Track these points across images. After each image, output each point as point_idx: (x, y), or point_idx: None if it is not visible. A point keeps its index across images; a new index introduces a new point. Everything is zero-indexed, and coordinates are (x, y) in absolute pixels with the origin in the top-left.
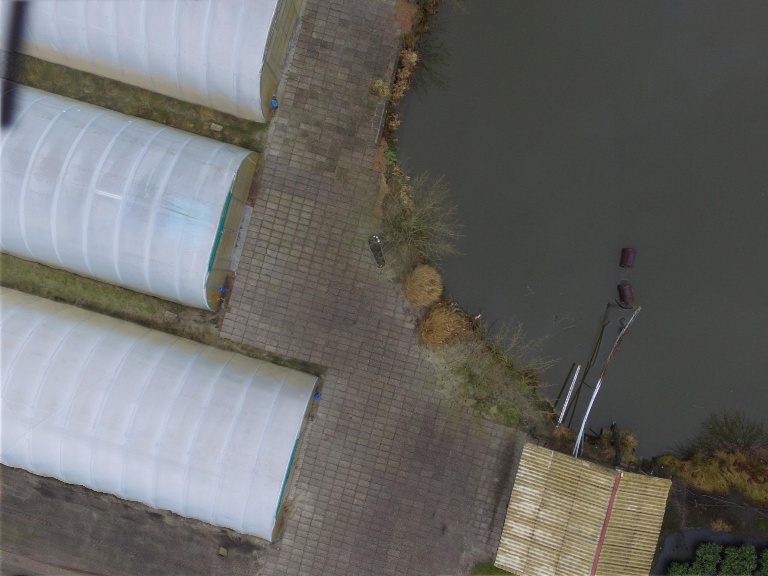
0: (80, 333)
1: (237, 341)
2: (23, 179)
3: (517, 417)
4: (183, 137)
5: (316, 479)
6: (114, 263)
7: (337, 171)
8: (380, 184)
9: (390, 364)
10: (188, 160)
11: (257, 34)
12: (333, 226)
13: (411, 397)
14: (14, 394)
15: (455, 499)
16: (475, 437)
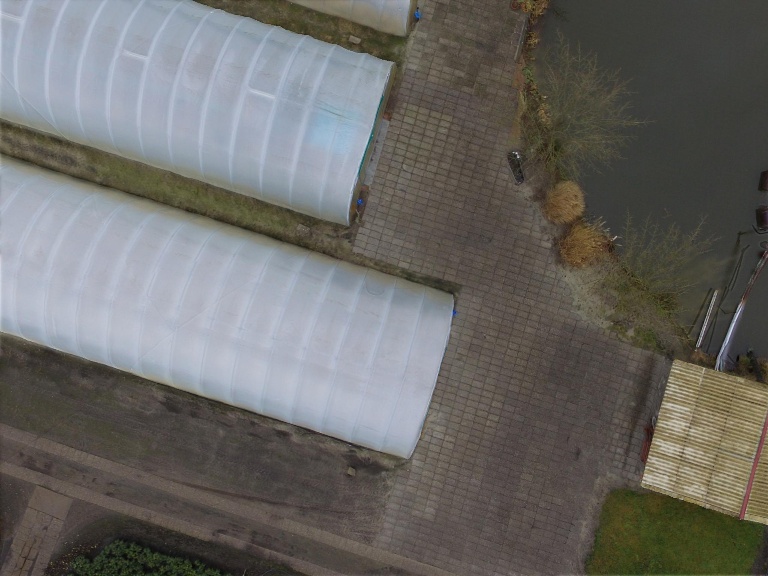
0: (220, 238)
1: (370, 256)
2: (175, 74)
3: (654, 340)
4: (327, 44)
5: (448, 399)
6: (259, 166)
7: (475, 87)
8: (518, 101)
9: (526, 283)
10: (339, 62)
11: None
12: (470, 142)
13: (547, 317)
14: (160, 293)
15: (590, 423)
16: (611, 360)
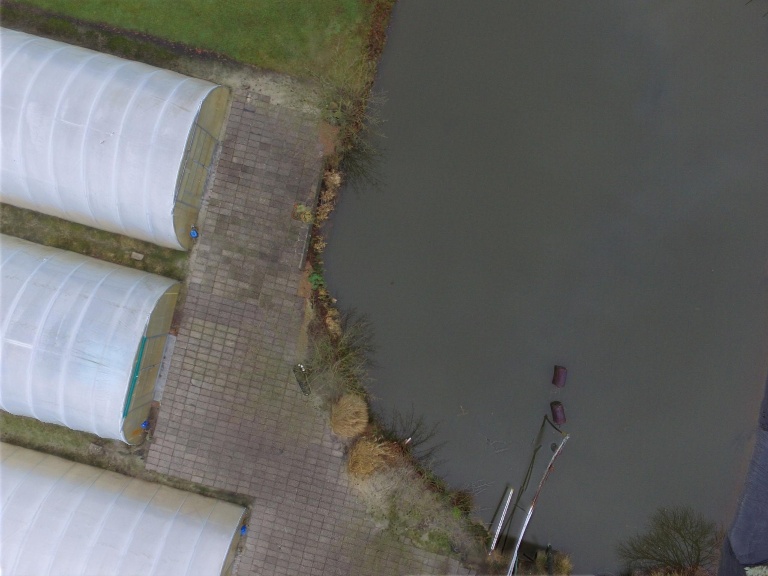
0: None
1: (163, 473)
2: None
3: (449, 545)
4: (100, 273)
5: None
6: (29, 408)
7: (261, 298)
8: (305, 310)
9: (319, 493)
10: (101, 303)
11: (166, 177)
12: (258, 354)
13: (340, 526)
14: None
15: None
16: (406, 566)
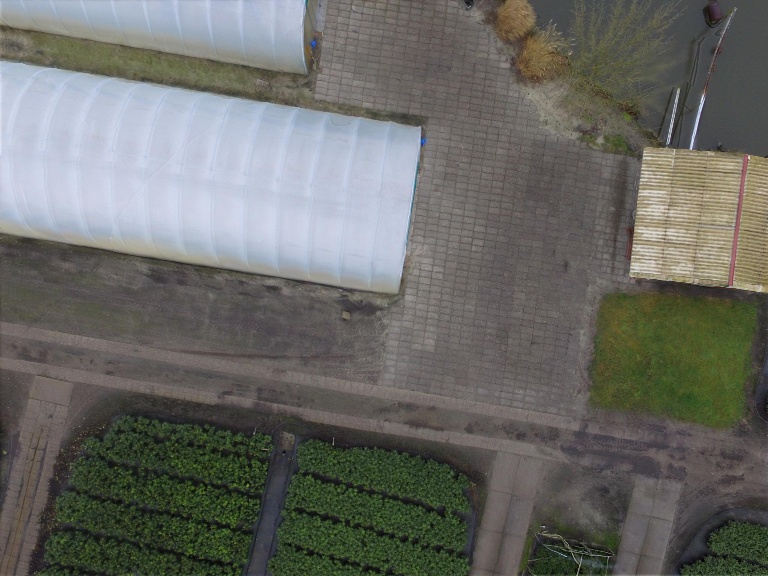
0: (178, 94)
1: (333, 101)
2: None
3: (625, 144)
4: None
5: (431, 230)
6: (206, 13)
7: None
8: None
9: (491, 106)
10: None
11: None
12: None
13: (516, 137)
14: (125, 146)
15: (574, 233)
16: (586, 169)
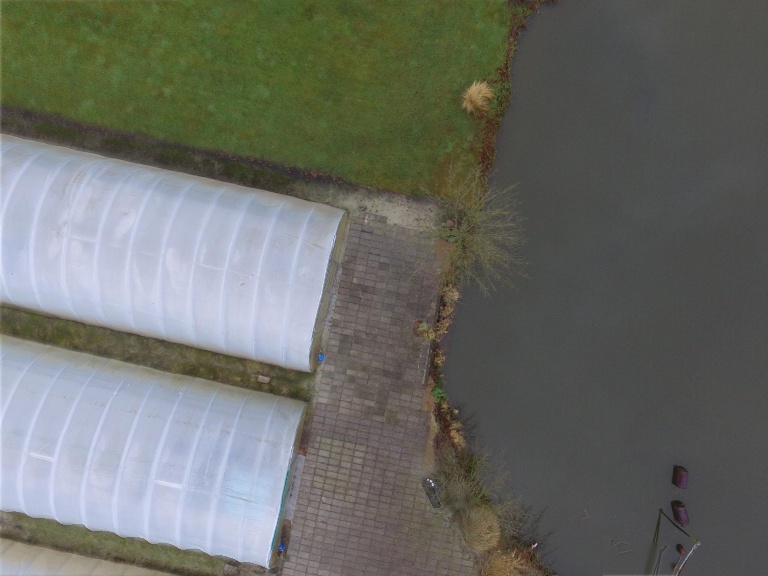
0: None
1: None
2: (82, 476)
3: None
4: (234, 403)
5: None
6: (176, 542)
7: (386, 414)
8: (430, 424)
9: None
10: (243, 438)
11: (305, 315)
12: (386, 469)
13: None
14: None
15: None
16: None
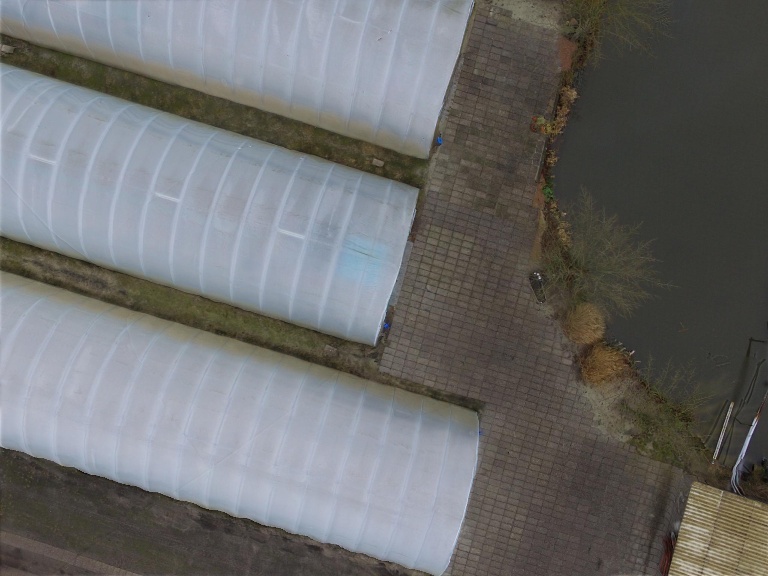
0: (251, 369)
1: (396, 375)
2: (207, 217)
3: (672, 453)
4: (353, 174)
5: (474, 513)
6: (289, 300)
7: (497, 207)
8: (539, 221)
9: (548, 400)
10: (366, 199)
11: (440, 75)
12: (493, 262)
13: (568, 433)
14: (196, 431)
15: (611, 534)
16: (631, 473)
